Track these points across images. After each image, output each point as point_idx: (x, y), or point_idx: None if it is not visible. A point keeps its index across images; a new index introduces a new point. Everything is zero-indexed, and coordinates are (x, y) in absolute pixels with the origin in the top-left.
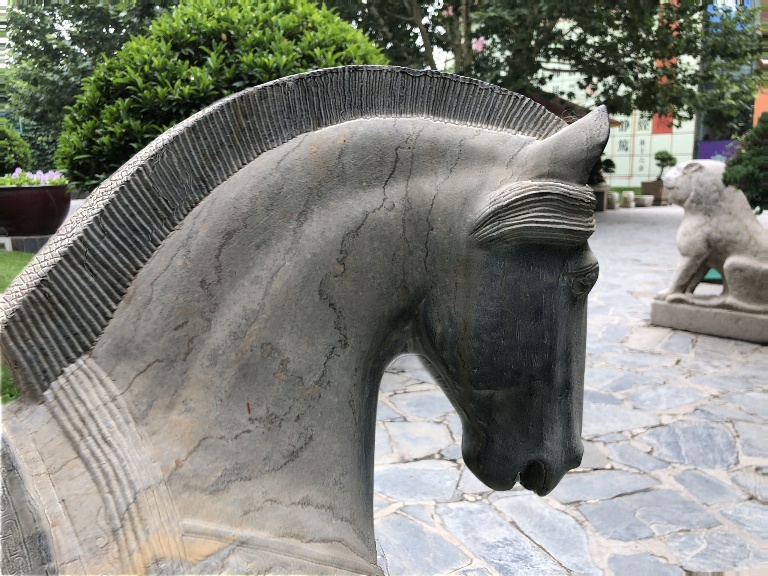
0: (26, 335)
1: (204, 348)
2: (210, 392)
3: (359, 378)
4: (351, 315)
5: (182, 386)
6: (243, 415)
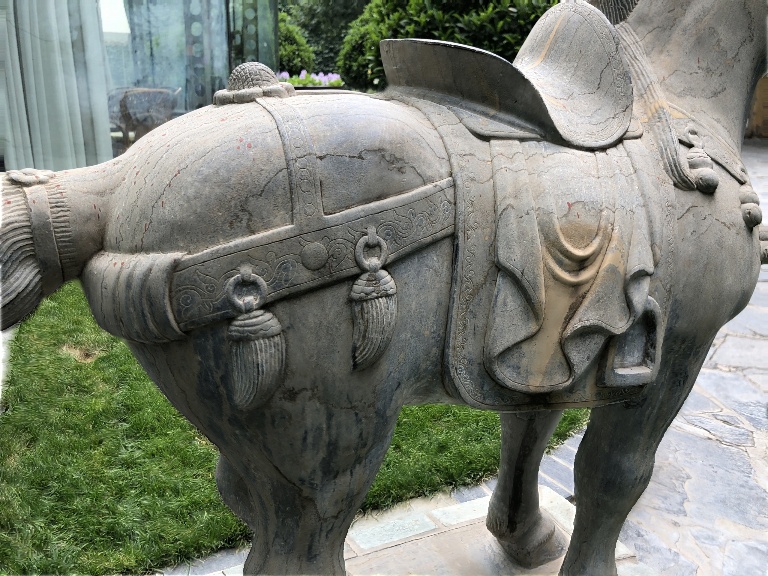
0: (606, 3)
1: (680, 25)
2: (681, 48)
3: (754, 65)
4: (759, 22)
5: (668, 43)
6: (695, 64)
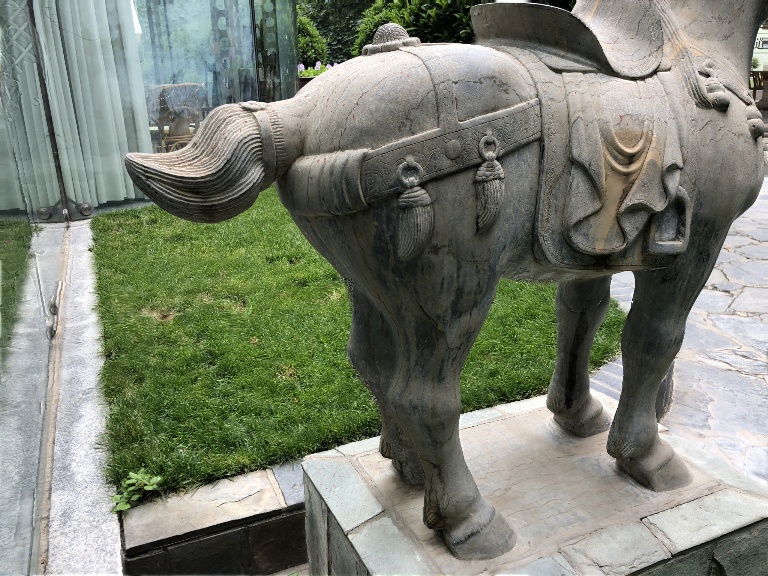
0: None
1: None
2: (698, 3)
3: (756, 14)
4: None
5: None
6: (709, 15)
